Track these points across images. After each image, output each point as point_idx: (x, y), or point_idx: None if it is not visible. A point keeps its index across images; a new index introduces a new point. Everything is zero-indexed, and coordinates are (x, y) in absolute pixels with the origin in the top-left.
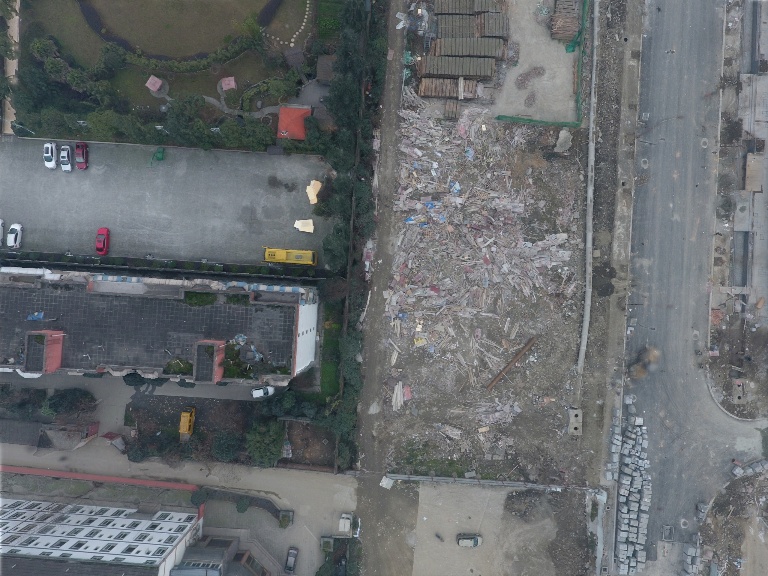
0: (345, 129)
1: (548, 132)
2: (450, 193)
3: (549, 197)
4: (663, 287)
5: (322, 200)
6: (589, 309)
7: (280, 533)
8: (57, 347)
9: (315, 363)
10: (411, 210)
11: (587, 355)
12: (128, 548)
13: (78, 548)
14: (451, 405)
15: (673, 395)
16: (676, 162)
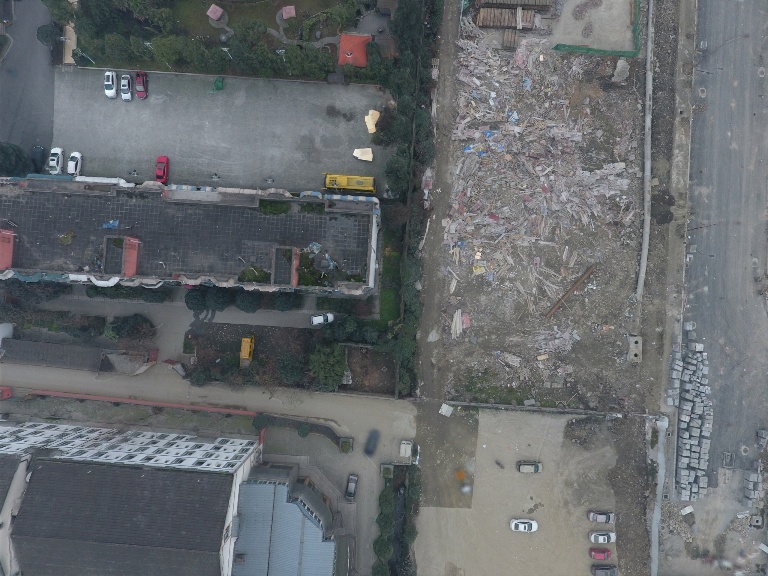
0: (409, 52)
1: (605, 62)
2: (508, 122)
3: (607, 127)
4: (722, 215)
5: (381, 129)
6: (648, 237)
7: (339, 460)
8: (133, 253)
9: (374, 291)
10: (469, 139)
11: (646, 283)
12: (197, 462)
13: (148, 461)
14: (510, 333)
15: (733, 322)
16: (734, 91)
